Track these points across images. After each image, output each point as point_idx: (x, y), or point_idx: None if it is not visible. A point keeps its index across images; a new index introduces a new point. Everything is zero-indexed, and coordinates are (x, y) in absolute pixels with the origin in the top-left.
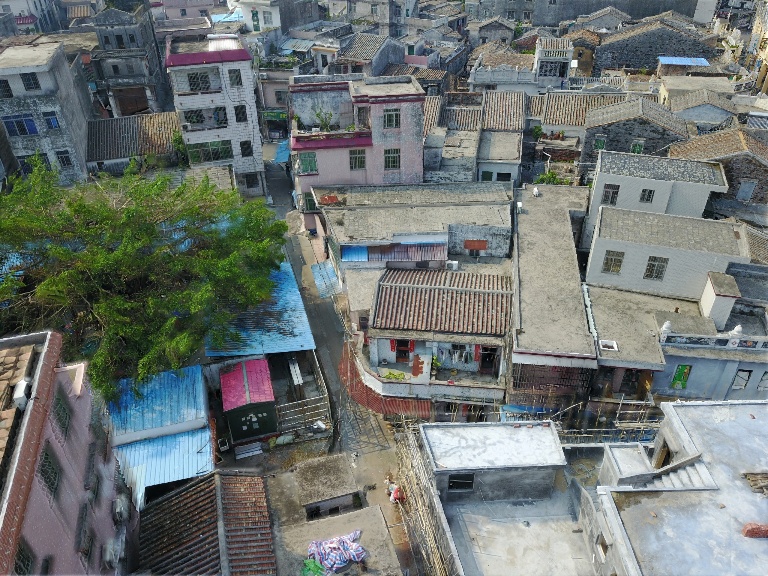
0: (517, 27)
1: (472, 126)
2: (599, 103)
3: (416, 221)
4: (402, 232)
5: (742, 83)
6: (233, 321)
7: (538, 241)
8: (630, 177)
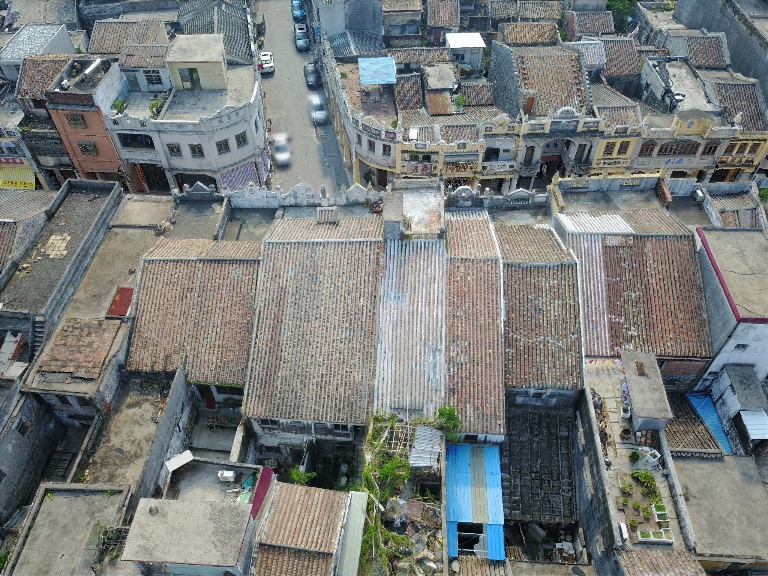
0: (618, 2)
1: (181, 1)
2: (206, 30)
3: (25, 4)
4: (13, 3)
5: (358, 120)
6: (2, 6)
7: (2, 39)
8: (16, 33)
